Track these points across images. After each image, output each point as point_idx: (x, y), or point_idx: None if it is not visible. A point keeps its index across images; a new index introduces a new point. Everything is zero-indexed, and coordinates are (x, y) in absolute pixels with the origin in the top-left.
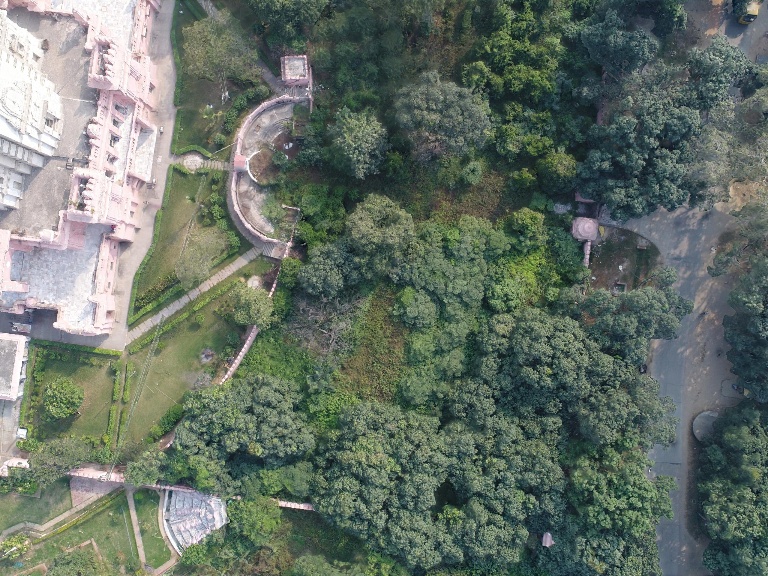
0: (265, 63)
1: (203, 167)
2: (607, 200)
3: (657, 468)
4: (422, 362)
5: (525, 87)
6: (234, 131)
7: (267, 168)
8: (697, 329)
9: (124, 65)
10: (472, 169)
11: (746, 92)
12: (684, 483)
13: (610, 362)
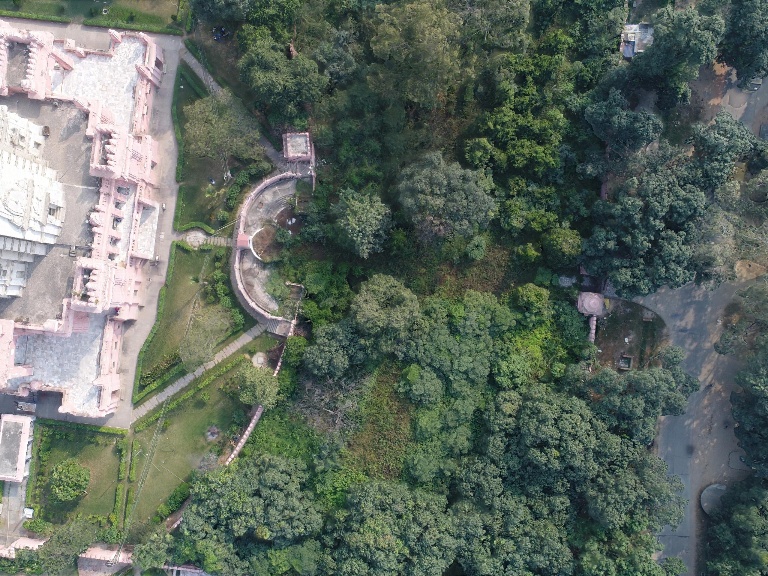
0: (267, 138)
1: (206, 243)
2: (613, 280)
3: (665, 541)
4: (428, 438)
5: (529, 162)
6: (237, 207)
7: (270, 245)
8: (704, 401)
9: (126, 151)
10: (476, 245)
11: (751, 167)
12: (692, 556)
13: (618, 443)
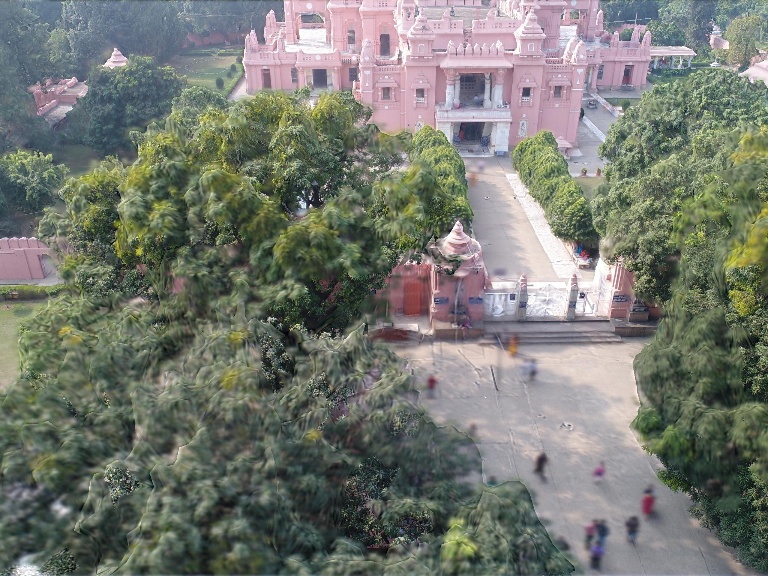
0: None
1: None
2: None
3: None
4: None
5: None
6: None
7: None
8: None
9: None
10: None
11: None
12: None
13: None
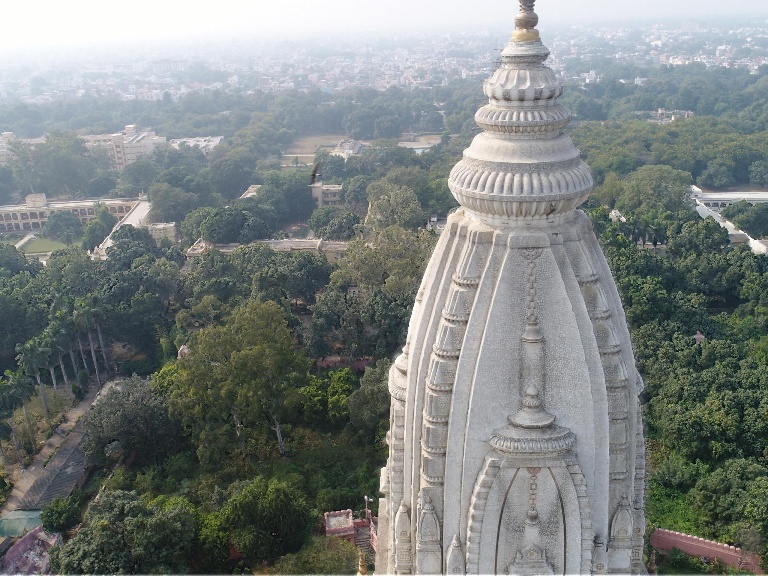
0: None
1: None
2: None
3: None
4: None
5: None
6: None
7: None
8: None
9: None
10: None
11: None
12: None
13: None
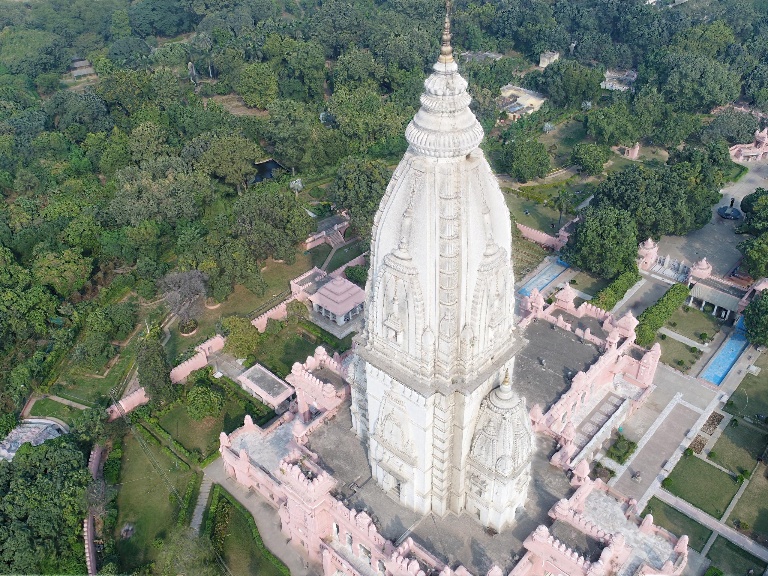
0: None
1: None
2: None
3: None
4: None
5: None
6: None
7: None
8: None
9: None
10: None
11: None
12: None
13: None
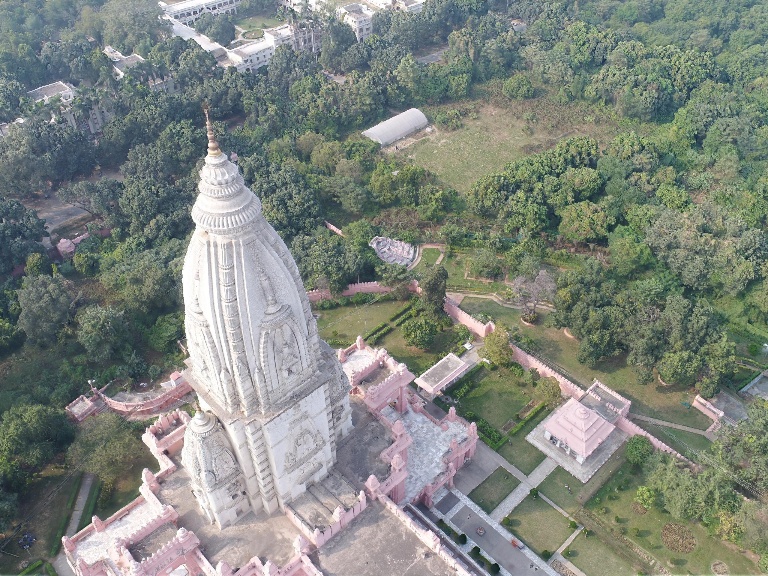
0: None
1: None
2: None
3: None
4: None
5: None
6: None
7: None
8: None
9: None
10: None
11: None
12: None
13: None
